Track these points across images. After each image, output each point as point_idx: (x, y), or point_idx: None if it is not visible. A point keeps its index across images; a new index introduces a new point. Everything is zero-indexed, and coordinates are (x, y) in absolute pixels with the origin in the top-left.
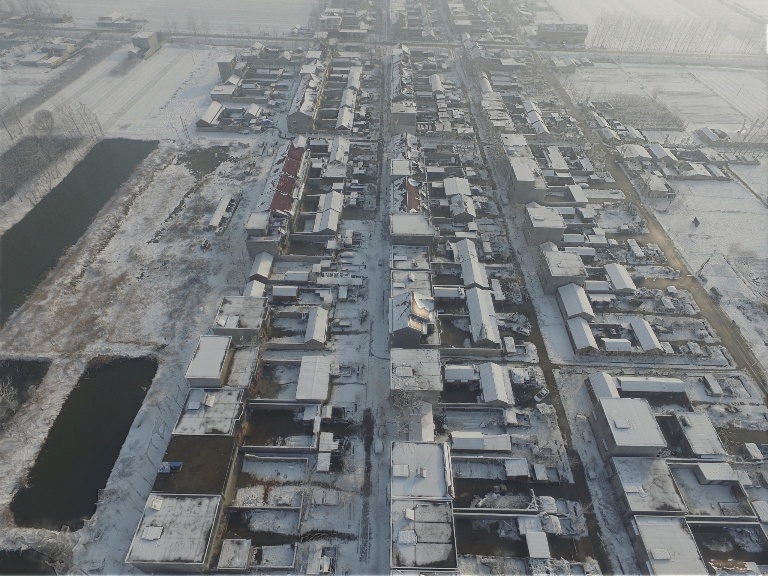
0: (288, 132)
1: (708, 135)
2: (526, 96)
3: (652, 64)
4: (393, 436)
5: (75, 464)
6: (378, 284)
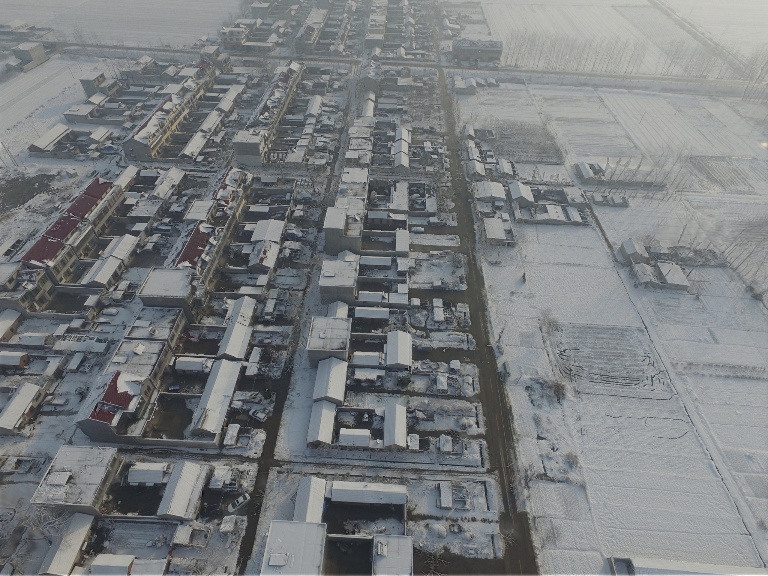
0: (127, 160)
1: (582, 171)
2: (403, 122)
3: (562, 86)
4: (35, 556)
5: None
6: None
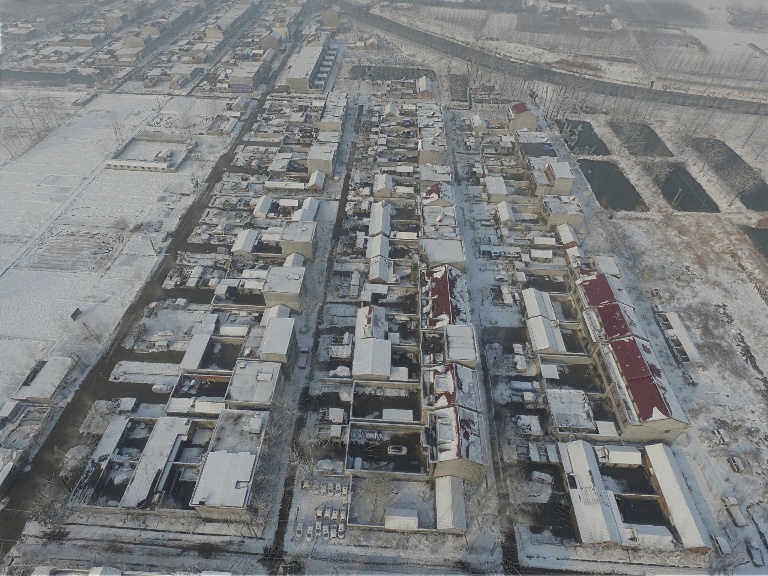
0: None
1: None
2: None
3: None
4: None
5: (604, 176)
6: (465, 252)
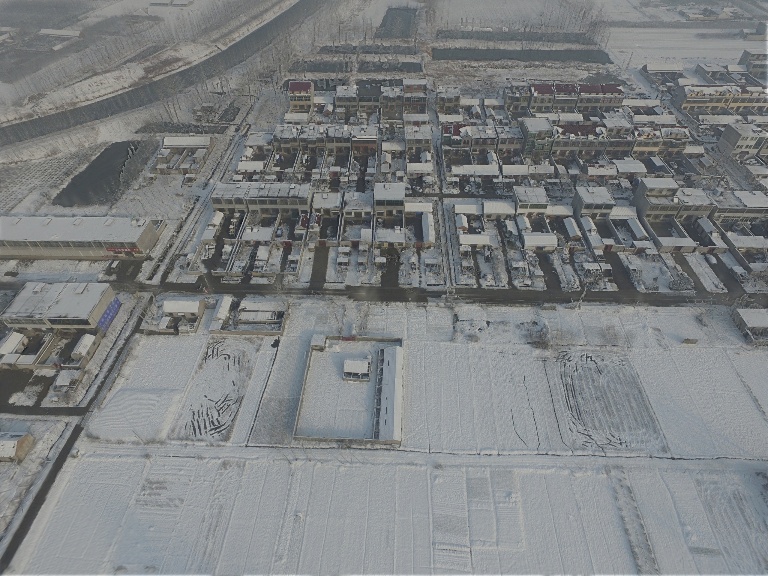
0: (670, 101)
1: None
2: None
3: None
4: None
5: None
6: None
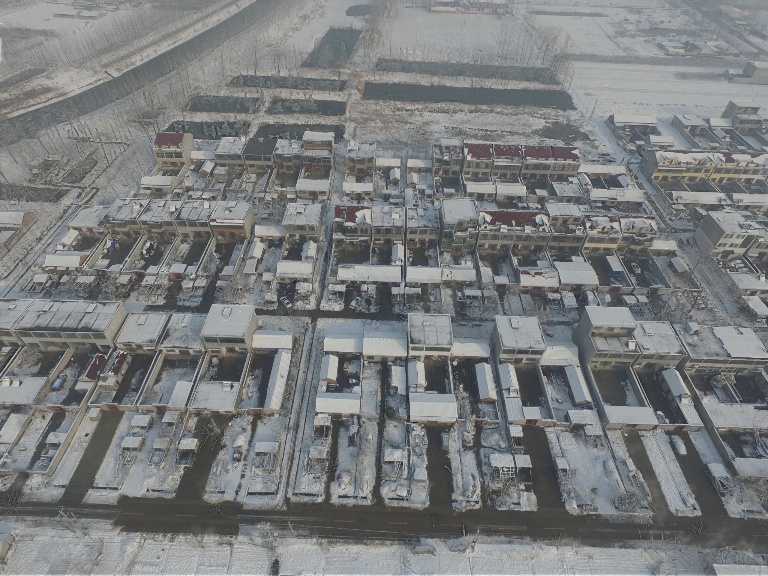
0: (638, 165)
1: None
2: None
3: None
4: None
5: None
6: None
